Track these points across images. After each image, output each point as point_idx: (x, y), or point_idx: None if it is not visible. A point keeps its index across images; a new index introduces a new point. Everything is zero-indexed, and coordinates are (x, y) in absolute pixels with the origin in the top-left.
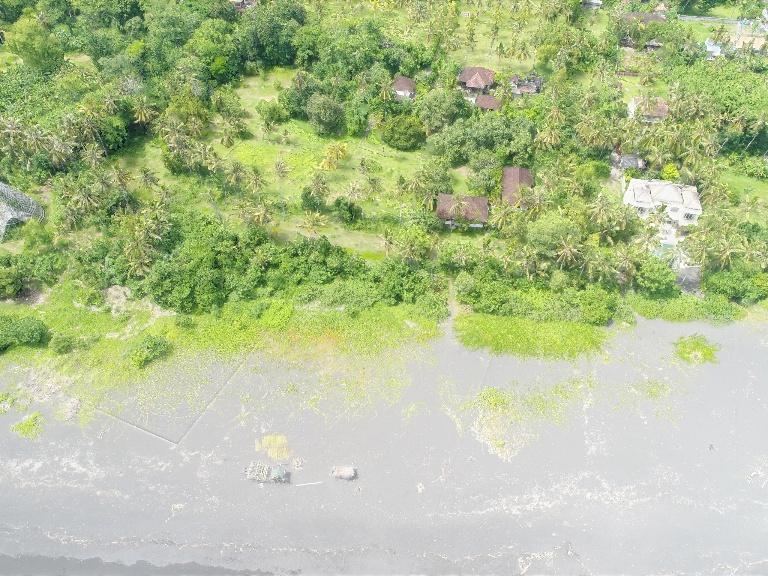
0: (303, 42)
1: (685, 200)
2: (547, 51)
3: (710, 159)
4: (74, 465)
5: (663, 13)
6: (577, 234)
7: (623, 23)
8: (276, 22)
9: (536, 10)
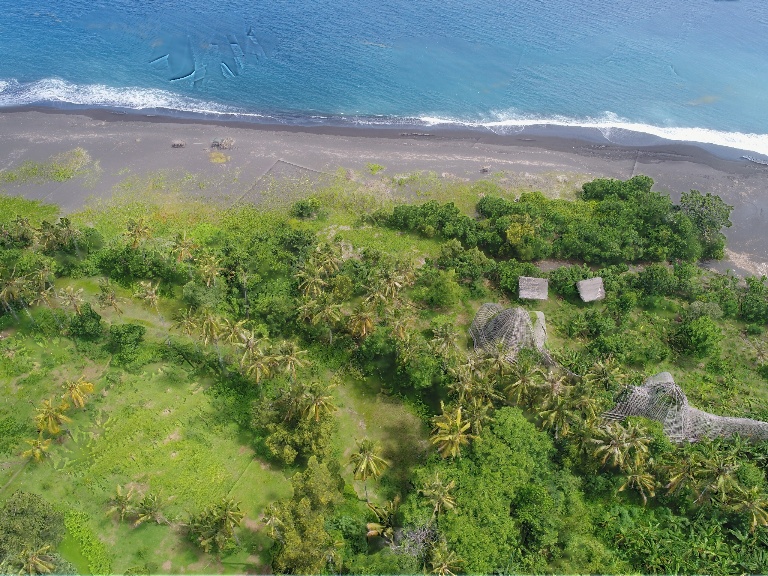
0: None
1: None
2: None
3: None
4: (340, 155)
5: None
6: None
7: None
8: None
9: None
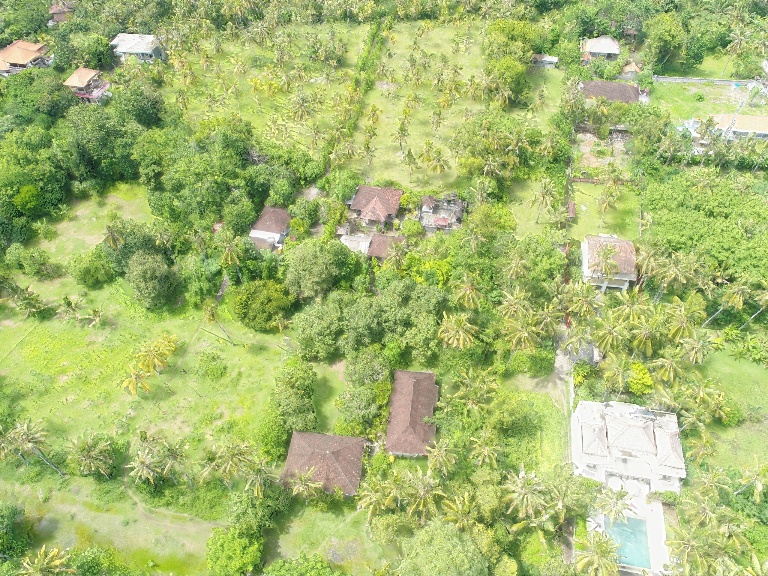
0: (145, 155)
1: (659, 450)
2: (470, 165)
3: (696, 375)
4: None
5: (635, 74)
6: (480, 566)
7: (579, 105)
8: (109, 128)
9: (465, 87)
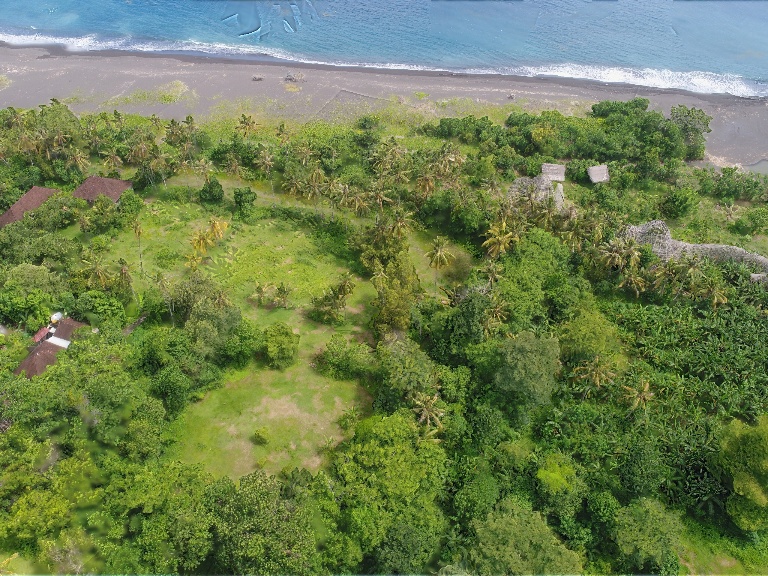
0: None
1: None
2: None
3: None
4: (391, 86)
5: None
6: None
7: None
8: None
9: None
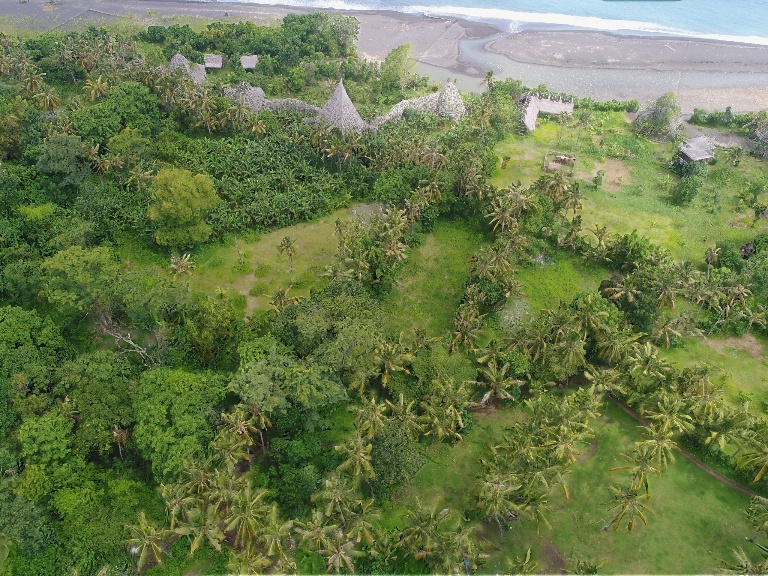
0: None
1: None
2: None
3: None
4: (133, 7)
5: None
6: None
7: None
8: None
9: None
